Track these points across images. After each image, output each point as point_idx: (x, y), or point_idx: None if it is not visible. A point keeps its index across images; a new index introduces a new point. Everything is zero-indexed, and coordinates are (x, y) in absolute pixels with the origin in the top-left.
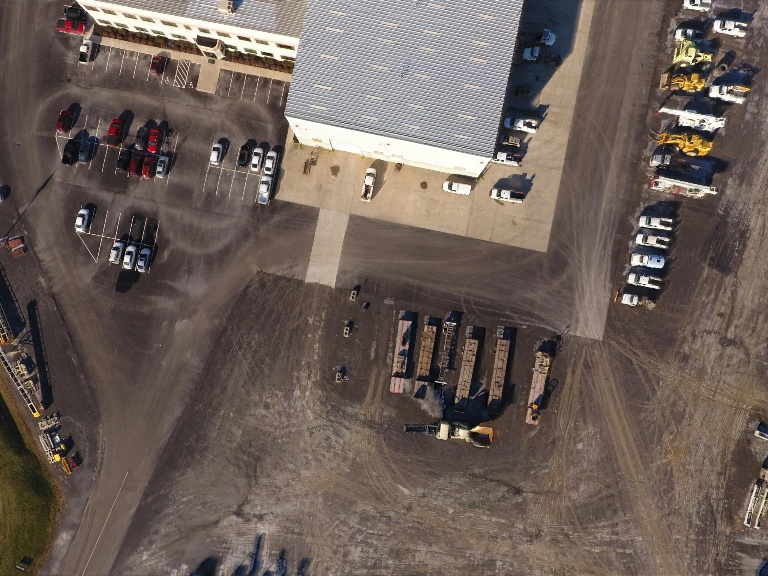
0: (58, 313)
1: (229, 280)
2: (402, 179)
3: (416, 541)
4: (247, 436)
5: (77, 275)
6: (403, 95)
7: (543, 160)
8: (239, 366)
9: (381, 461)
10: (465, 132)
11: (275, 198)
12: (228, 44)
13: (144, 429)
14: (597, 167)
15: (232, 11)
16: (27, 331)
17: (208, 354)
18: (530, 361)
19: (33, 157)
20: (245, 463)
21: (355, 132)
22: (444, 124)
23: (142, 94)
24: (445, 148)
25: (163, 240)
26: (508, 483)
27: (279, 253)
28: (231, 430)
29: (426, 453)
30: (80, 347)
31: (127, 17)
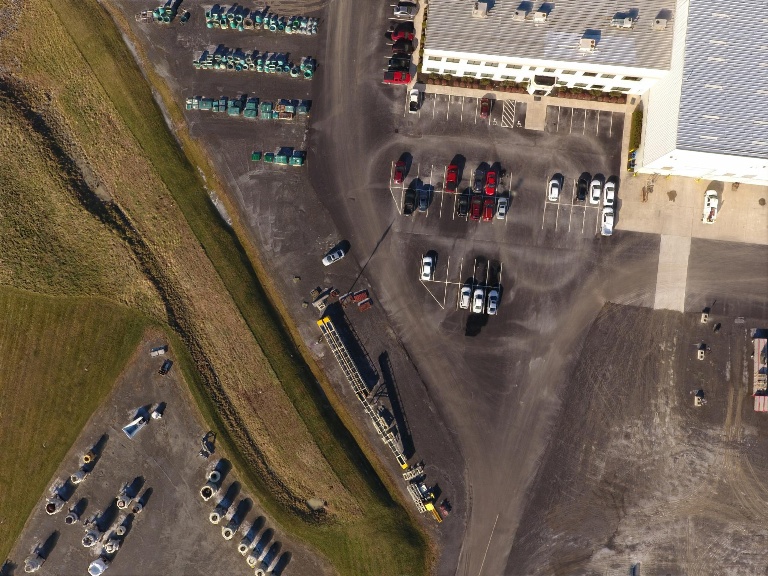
0: (410, 363)
1: (578, 314)
2: (740, 198)
3: None
4: (611, 468)
5: (425, 323)
6: None
7: None
8: (596, 399)
9: (748, 480)
10: None
11: (615, 228)
12: (560, 80)
13: (509, 470)
14: None
15: None
16: (381, 383)
17: (565, 390)
18: None
19: (369, 210)
20: (612, 495)
21: (742, 158)
22: None
23: (471, 137)
24: None
25: (508, 281)
26: None
27: (625, 283)
28: (594, 463)
29: None
30: (436, 395)
31: (468, 64)
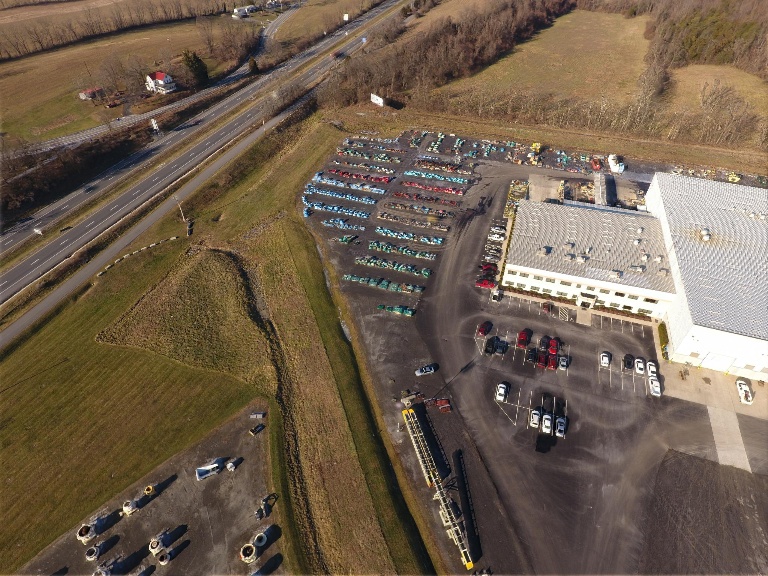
0: (482, 464)
1: (644, 453)
2: None
3: None
4: None
5: (498, 433)
6: None
7: None
8: (682, 541)
9: None
10: None
11: (663, 394)
12: (599, 300)
13: None
14: None
15: (618, 277)
16: (452, 477)
17: (644, 523)
18: None
19: (457, 348)
20: None
21: (749, 340)
22: None
23: (537, 321)
24: None
25: (573, 414)
26: None
27: (684, 436)
28: None
29: None
30: (507, 499)
31: (534, 279)
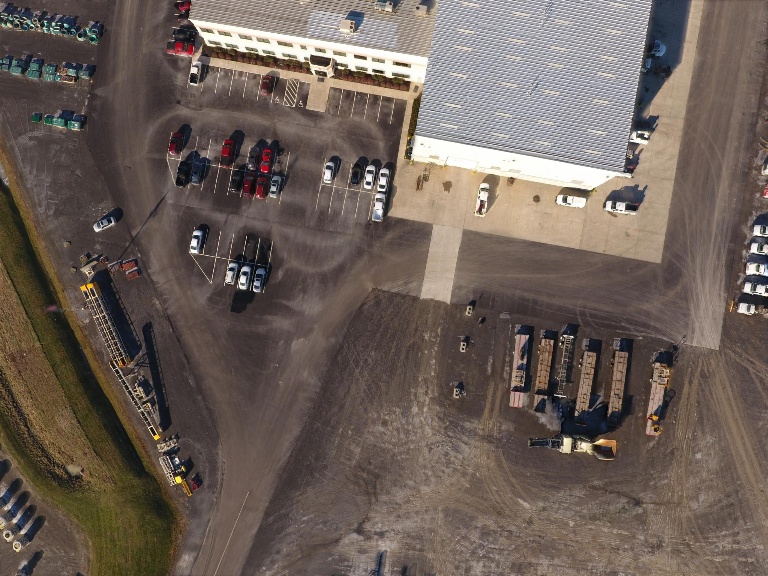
0: (174, 335)
1: (344, 298)
2: (515, 193)
3: (538, 555)
4: (366, 454)
5: (192, 296)
6: (533, 112)
7: (655, 171)
8: (356, 384)
9: (501, 475)
10: (595, 147)
11: (388, 215)
12: (340, 62)
13: (263, 449)
14: (709, 177)
15: (353, 31)
16: (143, 354)
17: (325, 372)
18: (647, 372)
19: (145, 179)
20: (365, 481)
21: (484, 149)
22: (574, 140)
23: (252, 114)
24: (576, 164)
25: (277, 259)
26: (628, 495)
27: (393, 270)
28: (350, 448)
29: (545, 466)
30: (197, 368)
31: (242, 38)
